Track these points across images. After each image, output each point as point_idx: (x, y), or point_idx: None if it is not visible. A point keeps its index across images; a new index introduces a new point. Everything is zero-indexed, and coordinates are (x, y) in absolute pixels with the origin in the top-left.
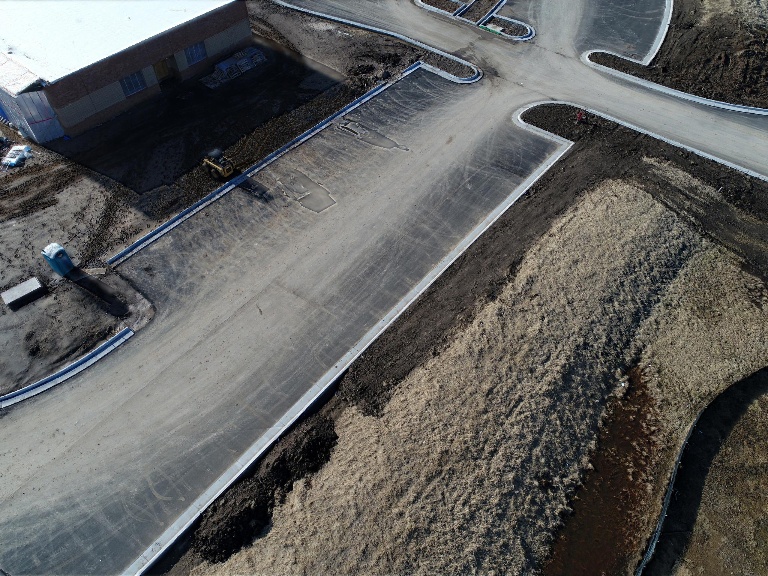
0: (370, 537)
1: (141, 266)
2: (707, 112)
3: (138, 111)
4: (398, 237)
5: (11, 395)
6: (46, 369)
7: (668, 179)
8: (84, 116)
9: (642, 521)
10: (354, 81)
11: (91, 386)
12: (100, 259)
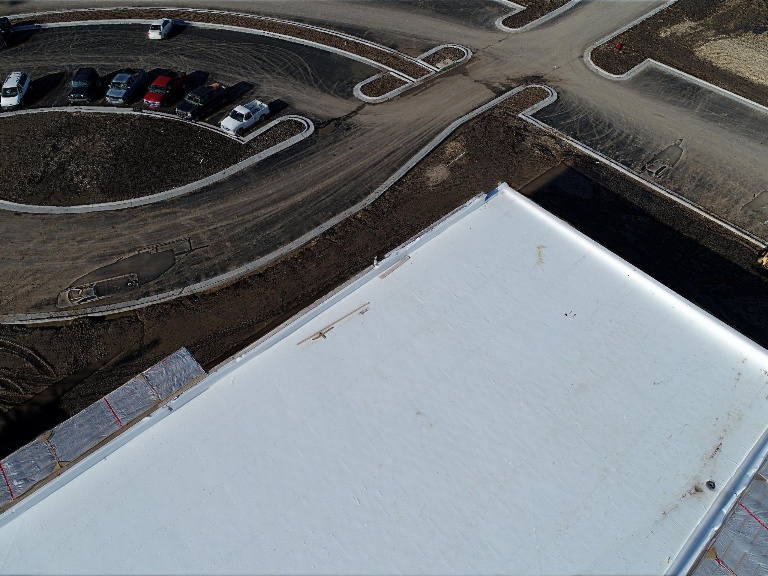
0: None
1: None
2: (591, 3)
3: None
4: None
5: None
6: None
7: (687, 32)
8: None
9: None
10: (567, 160)
11: None
12: None
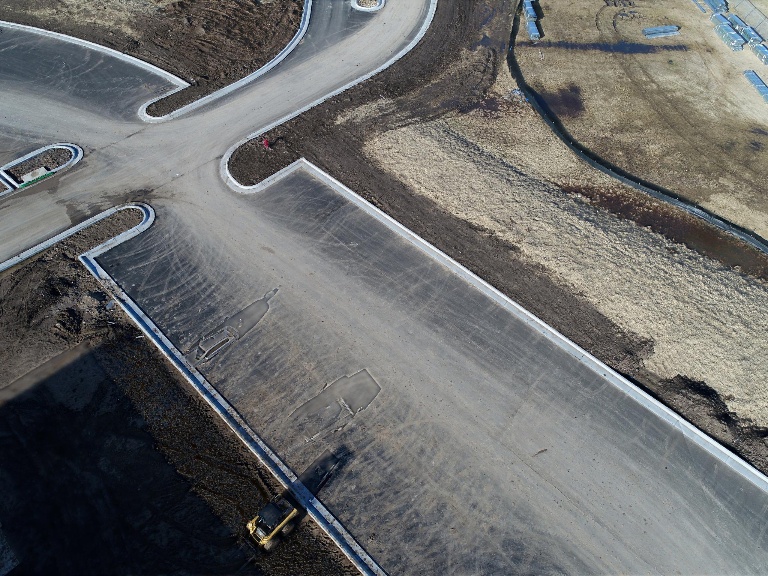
0: (760, 352)
1: None
2: (278, 74)
3: None
4: (429, 312)
5: None
6: None
7: (369, 117)
8: None
9: (679, 213)
10: (95, 336)
11: None
12: None
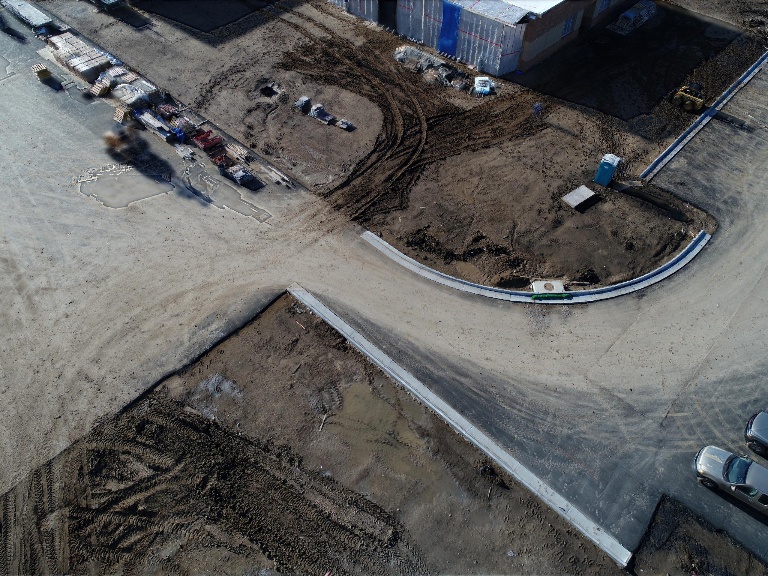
0: None
1: (674, 181)
2: None
3: (568, 52)
4: None
5: (637, 280)
6: (650, 261)
7: None
8: (537, 52)
9: None
10: (754, 33)
11: (706, 277)
12: (629, 174)
